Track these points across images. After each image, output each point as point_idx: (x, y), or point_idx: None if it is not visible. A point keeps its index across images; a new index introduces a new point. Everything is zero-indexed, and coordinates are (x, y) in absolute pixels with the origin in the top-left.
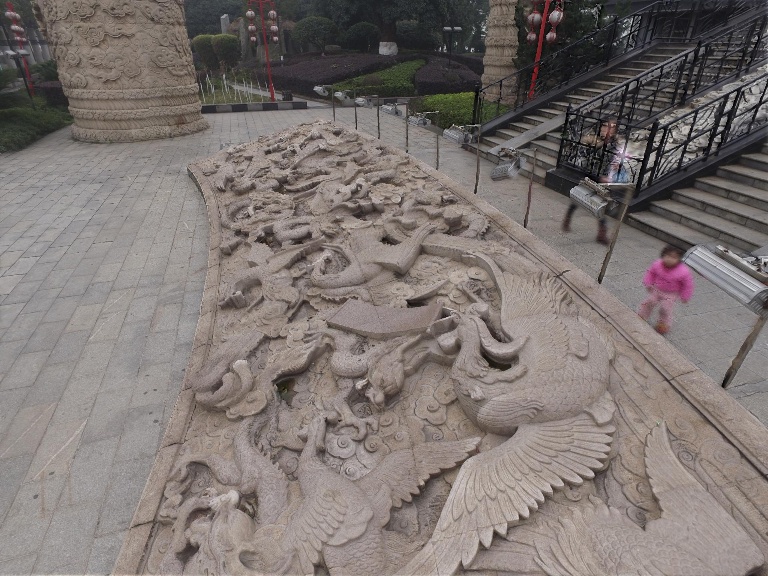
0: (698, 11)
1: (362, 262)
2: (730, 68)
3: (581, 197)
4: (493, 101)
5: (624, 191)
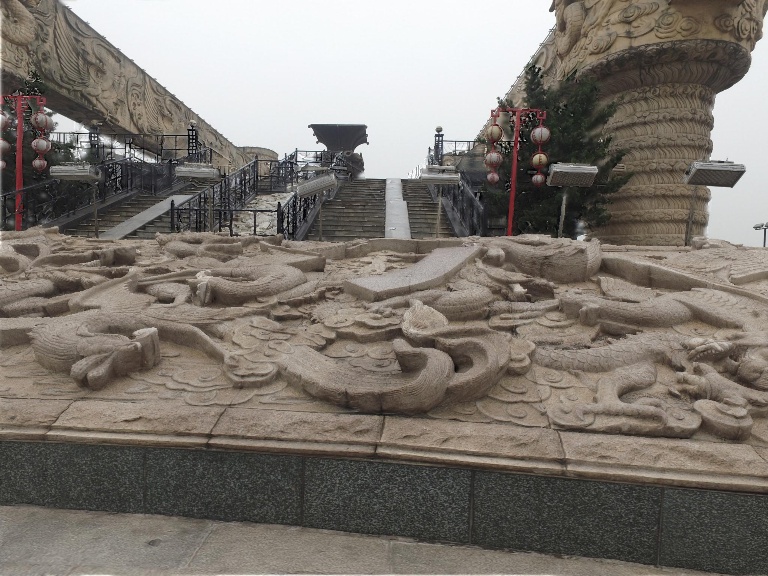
0: (154, 174)
1: (279, 263)
2: None
3: (437, 175)
4: None
5: None
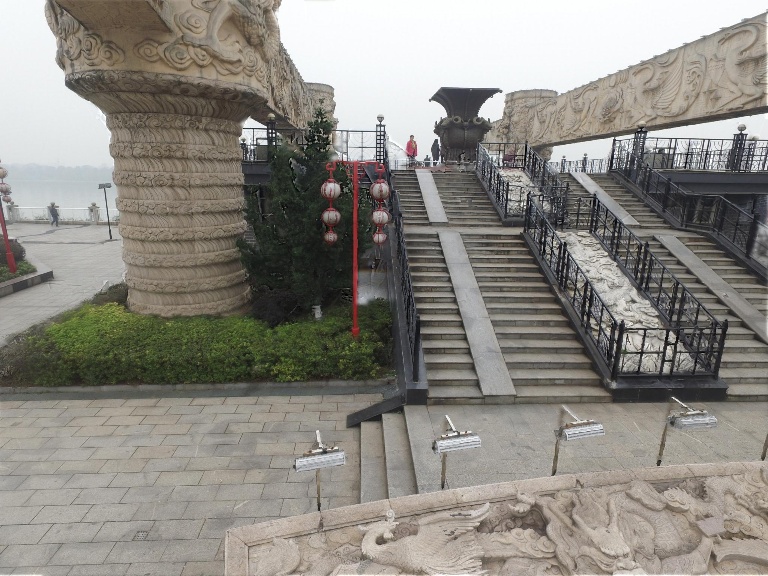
0: None
1: None
2: (507, 250)
3: None
4: (203, 315)
5: (700, 378)
